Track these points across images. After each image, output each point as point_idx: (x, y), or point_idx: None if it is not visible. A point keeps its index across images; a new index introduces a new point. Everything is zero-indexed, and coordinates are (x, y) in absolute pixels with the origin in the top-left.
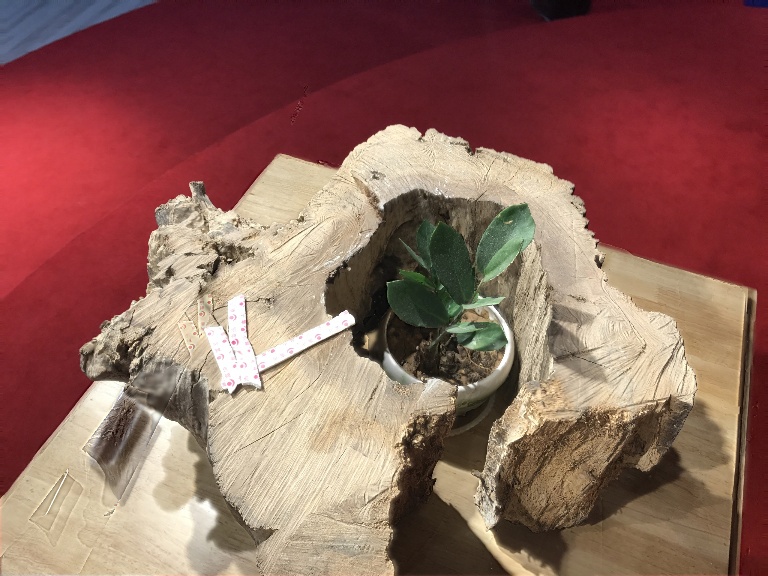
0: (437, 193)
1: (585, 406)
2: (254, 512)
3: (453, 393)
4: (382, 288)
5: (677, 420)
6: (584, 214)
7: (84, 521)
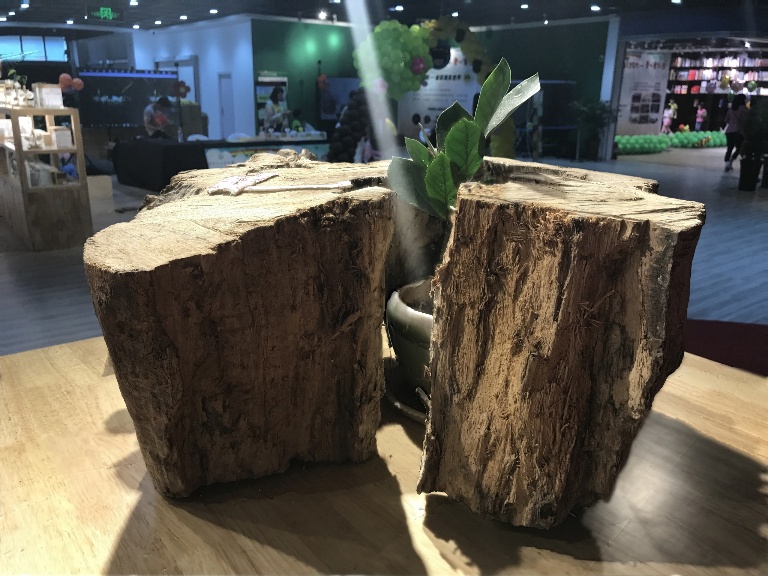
0: (499, 163)
1: (519, 200)
2: (144, 219)
3: (387, 193)
4: (432, 273)
5: (660, 266)
6: (653, 187)
7: (3, 60)
